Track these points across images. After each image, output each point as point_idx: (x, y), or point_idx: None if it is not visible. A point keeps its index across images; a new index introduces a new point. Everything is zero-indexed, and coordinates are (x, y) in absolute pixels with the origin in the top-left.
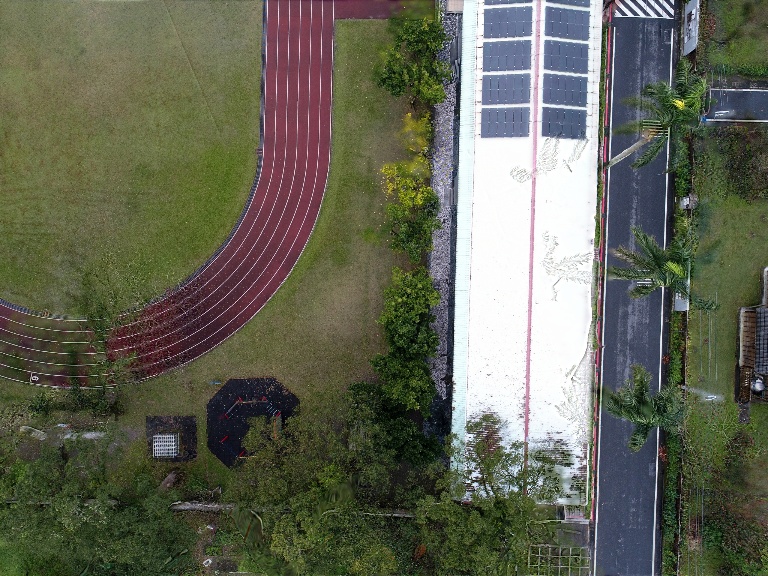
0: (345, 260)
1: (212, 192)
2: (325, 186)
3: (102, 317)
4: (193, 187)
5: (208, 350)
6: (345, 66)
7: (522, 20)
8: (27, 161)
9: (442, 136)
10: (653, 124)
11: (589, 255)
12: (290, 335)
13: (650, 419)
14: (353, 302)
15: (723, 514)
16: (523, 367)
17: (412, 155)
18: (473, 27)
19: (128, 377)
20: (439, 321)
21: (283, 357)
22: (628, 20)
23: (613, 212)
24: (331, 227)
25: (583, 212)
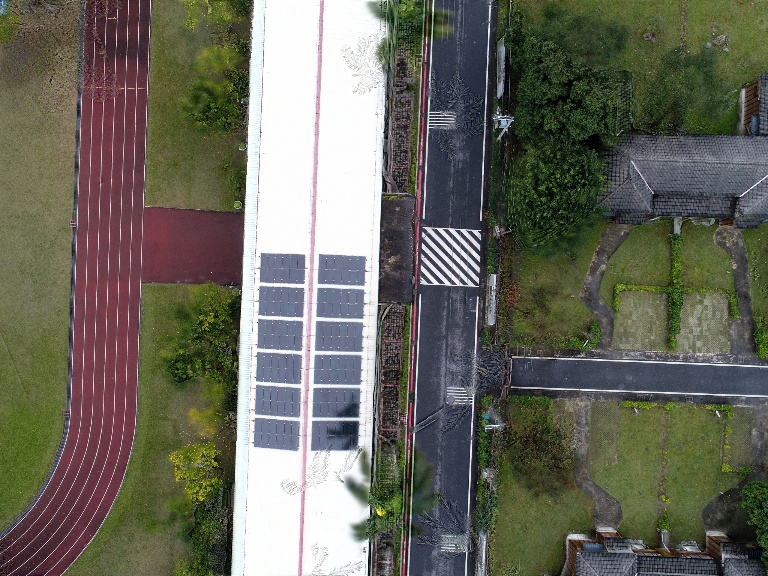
0: (150, 522)
1: (19, 454)
2: (131, 449)
3: None
4: None
5: None
6: (152, 330)
7: (293, 334)
8: None
9: None
10: (458, 391)
11: (361, 563)
12: None
13: None
14: (158, 564)
15: None
16: None
17: (218, 419)
18: (248, 335)
19: None
20: None
21: None
22: (433, 288)
23: (418, 477)
24: (136, 490)
25: (356, 520)
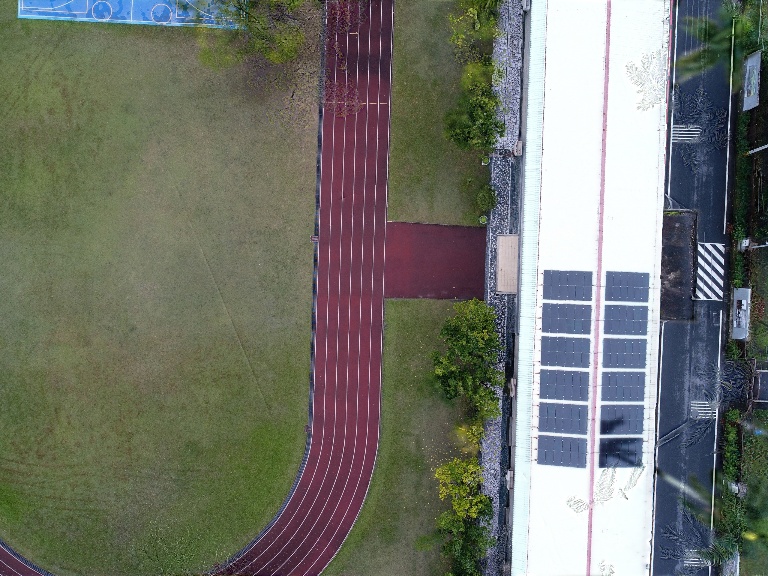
0: (393, 538)
1: (261, 469)
2: (374, 464)
3: None
4: (242, 464)
5: None
6: (394, 345)
7: (580, 351)
8: (77, 437)
9: (491, 415)
10: (701, 405)
11: None
12: None
13: None
14: None
15: None
16: None
17: (461, 434)
18: (530, 352)
19: None
20: None
21: None
22: None
23: (661, 492)
24: (379, 505)
25: (638, 537)
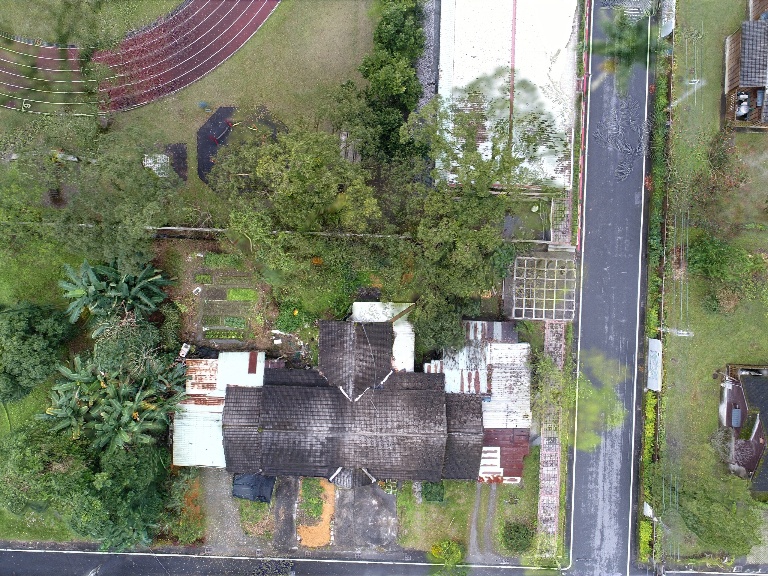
0: None
1: None
2: None
3: (94, 45)
4: None
5: (199, 78)
6: None
7: None
8: None
9: None
10: None
11: None
12: (280, 63)
13: (636, 148)
14: (342, 31)
15: (708, 237)
16: (508, 46)
17: None
18: None
19: (119, 103)
20: (426, 11)
21: (273, 85)
22: None
23: None
24: None
25: None
